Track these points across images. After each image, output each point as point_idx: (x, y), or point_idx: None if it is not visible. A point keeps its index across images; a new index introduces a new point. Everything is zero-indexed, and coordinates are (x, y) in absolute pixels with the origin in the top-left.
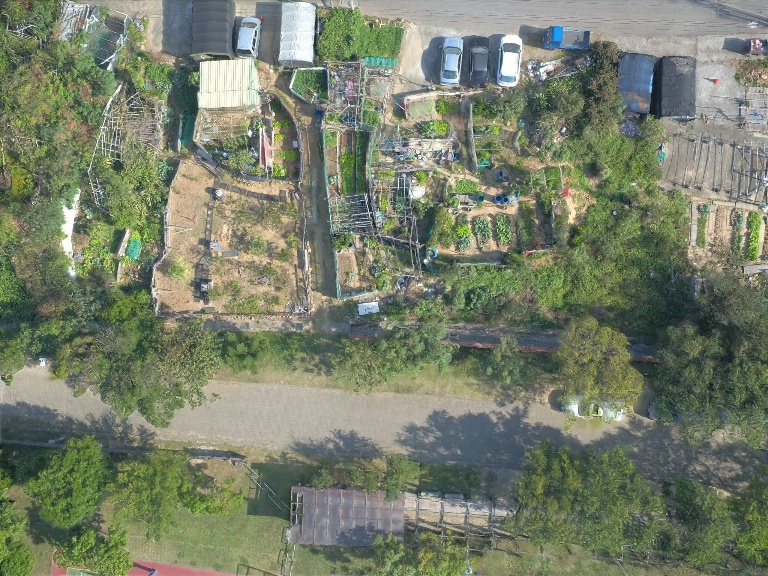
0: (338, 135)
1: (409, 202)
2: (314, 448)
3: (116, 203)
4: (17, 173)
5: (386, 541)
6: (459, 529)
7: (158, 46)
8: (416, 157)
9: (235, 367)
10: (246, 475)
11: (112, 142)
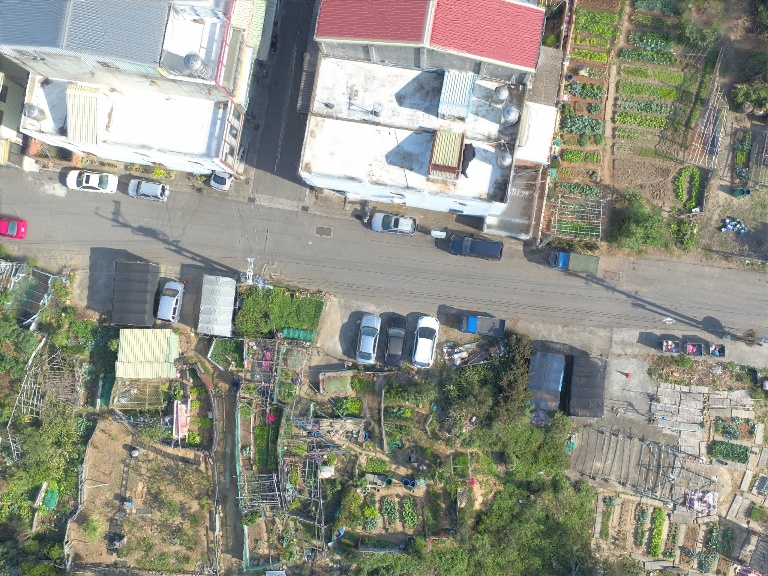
0: None
1: (317, 484)
2: None
3: (33, 461)
4: None
5: None
6: None
7: (83, 301)
8: (328, 433)
9: None
10: None
11: (32, 400)
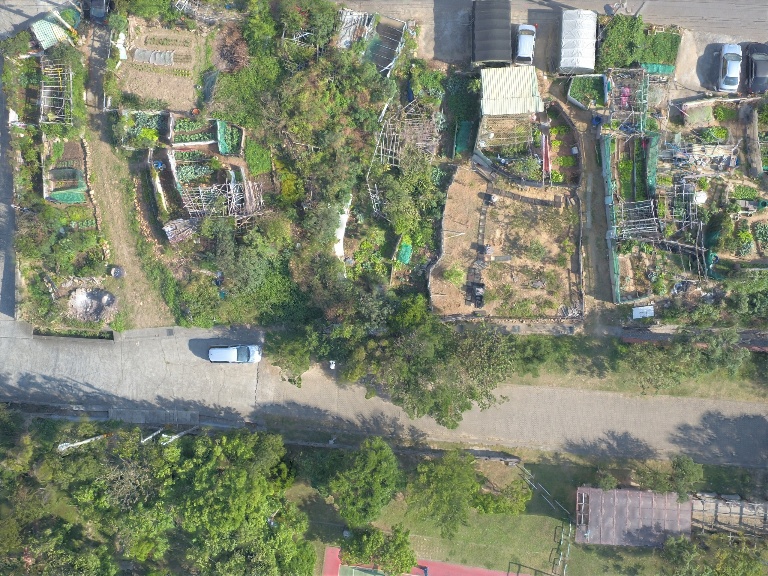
0: None
1: (695, 208)
2: (588, 449)
3: (396, 208)
4: (287, 178)
5: (678, 541)
6: (734, 529)
7: (430, 53)
8: (695, 163)
9: (520, 370)
10: (519, 475)
11: (391, 148)
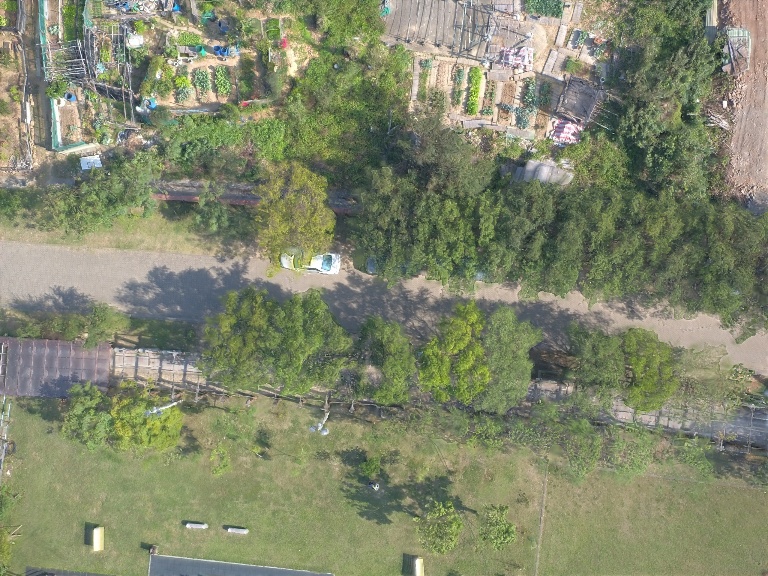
0: None
1: (123, 49)
2: (33, 304)
3: None
4: None
5: (85, 389)
6: (177, 387)
7: None
8: (138, 8)
9: None
10: None
11: None
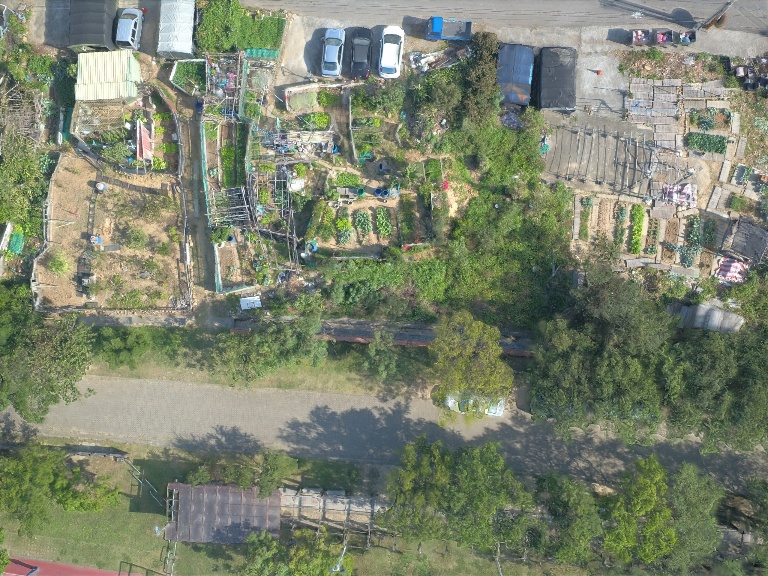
0: (215, 127)
1: (286, 195)
2: (196, 444)
3: None
4: None
5: (260, 538)
6: (341, 526)
7: (40, 38)
8: (297, 150)
9: (111, 362)
10: (128, 471)
11: None
